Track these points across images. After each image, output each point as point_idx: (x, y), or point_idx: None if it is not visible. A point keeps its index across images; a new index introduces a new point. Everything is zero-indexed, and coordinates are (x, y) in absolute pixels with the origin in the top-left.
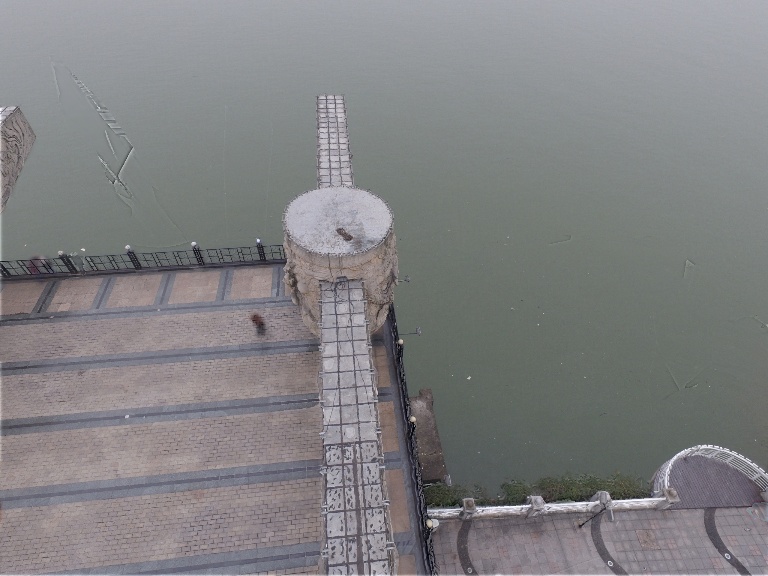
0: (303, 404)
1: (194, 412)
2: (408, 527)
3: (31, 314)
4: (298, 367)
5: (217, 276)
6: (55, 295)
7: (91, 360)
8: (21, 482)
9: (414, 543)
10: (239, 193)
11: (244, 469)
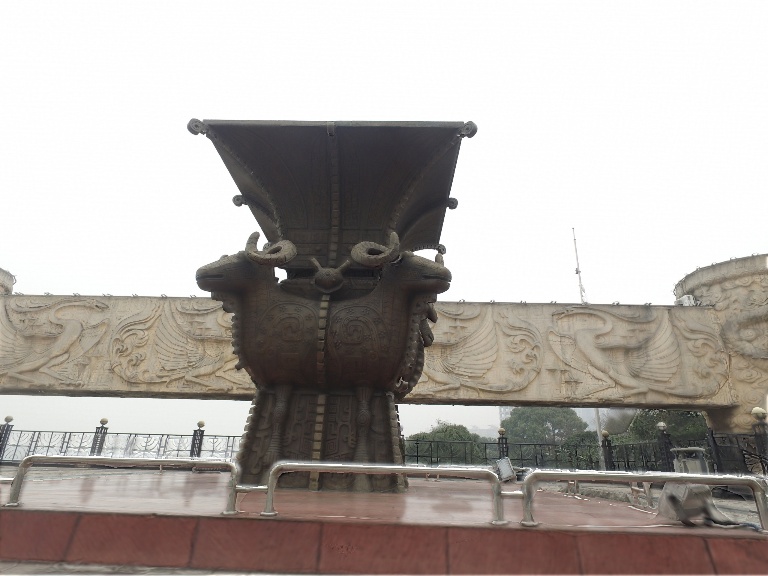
0: None
1: None
2: None
3: None
4: None
5: None
6: None
7: None
8: None
9: None
10: None
11: None
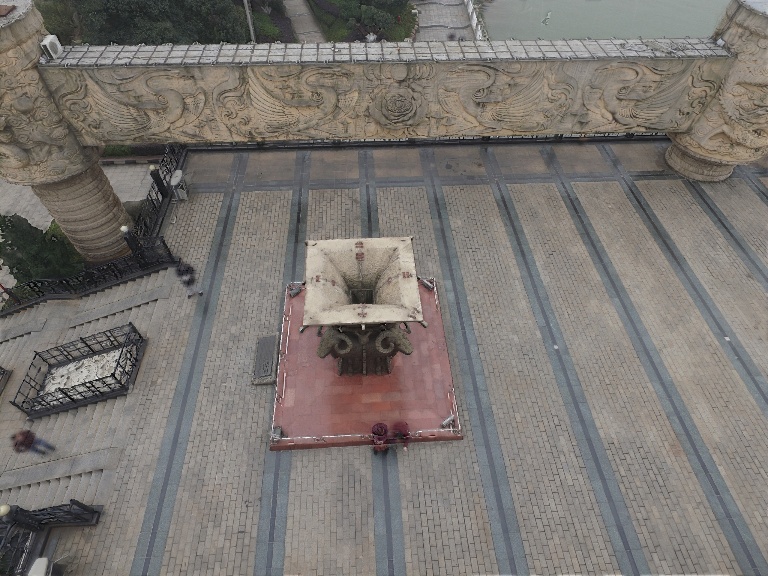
0: None
1: None
2: None
3: None
4: None
5: None
6: None
7: None
8: (621, 269)
9: None
10: None
11: (735, 509)
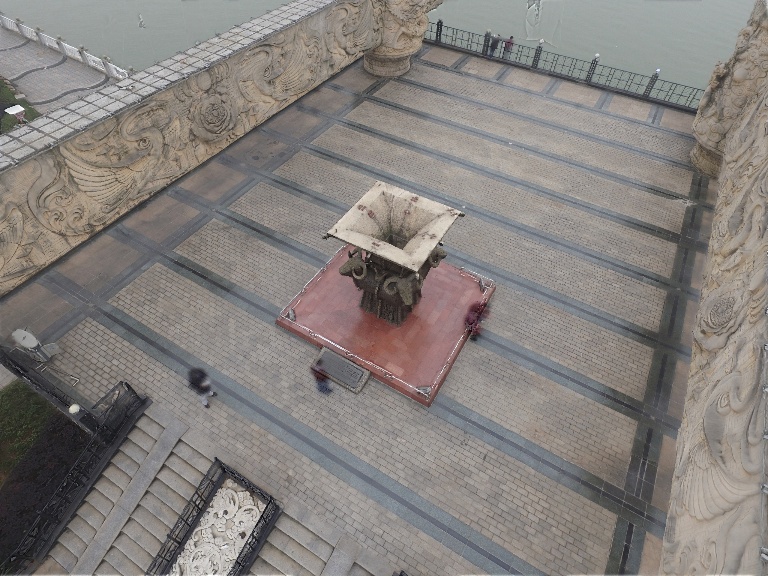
0: (662, 194)
1: (563, 161)
2: None
3: (450, 67)
4: (663, 171)
5: (598, 93)
6: (467, 63)
7: (489, 105)
8: (433, 146)
9: None
10: (629, 50)
11: (599, 208)
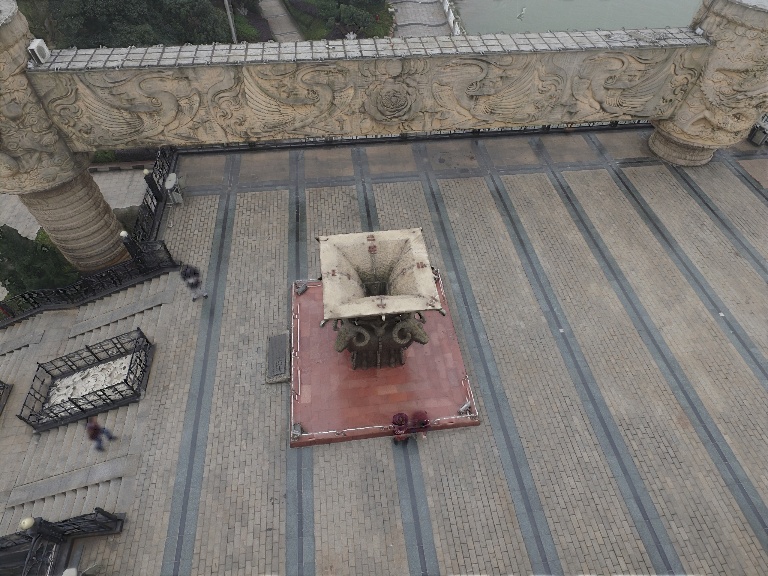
0: None
1: None
2: None
3: (764, 189)
4: None
5: None
6: None
7: (757, 257)
8: (617, 253)
9: None
10: None
11: (742, 474)
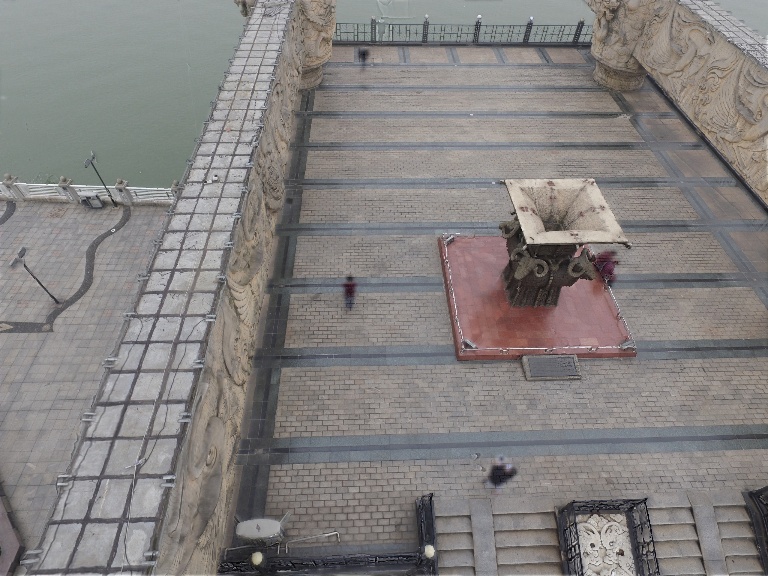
0: (607, 116)
1: (523, 115)
2: (727, 175)
3: (354, 63)
4: (590, 99)
5: (490, 50)
6: (365, 54)
7: (422, 87)
8: (416, 139)
9: (736, 182)
10: (475, 8)
11: (581, 143)
